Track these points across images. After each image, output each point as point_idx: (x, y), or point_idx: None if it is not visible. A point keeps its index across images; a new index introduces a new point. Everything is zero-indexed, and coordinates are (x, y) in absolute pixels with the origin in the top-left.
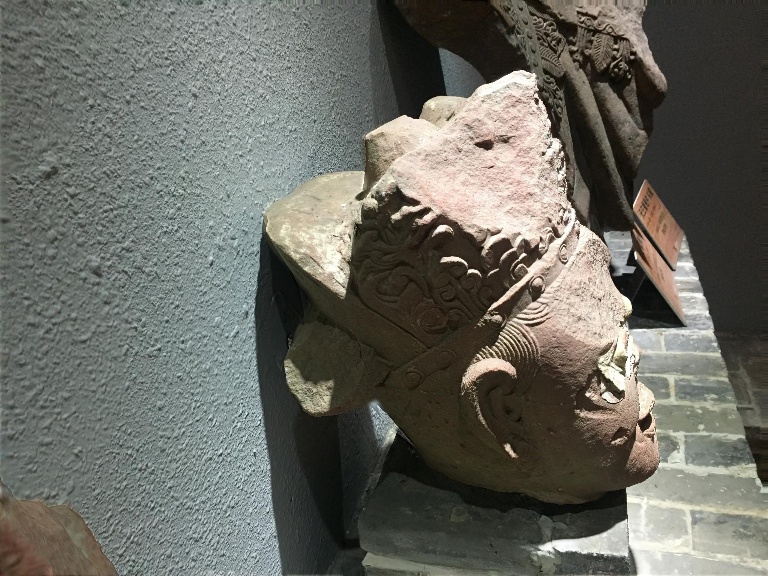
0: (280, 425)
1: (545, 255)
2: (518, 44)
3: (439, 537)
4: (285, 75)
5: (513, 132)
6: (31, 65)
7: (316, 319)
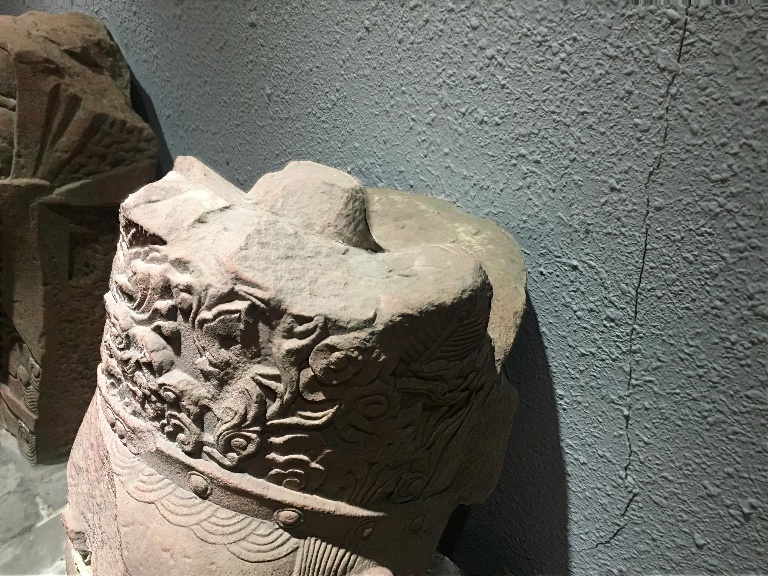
0: None
1: None
2: None
3: None
4: (545, 77)
5: None
6: None
7: None
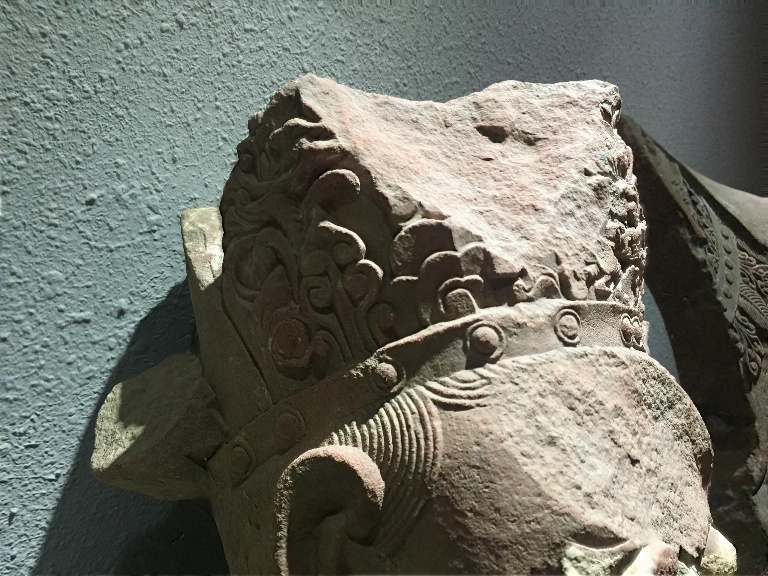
0: (99, 518)
1: (524, 304)
2: (705, 260)
3: None
4: None
5: (547, 134)
6: None
7: (191, 348)
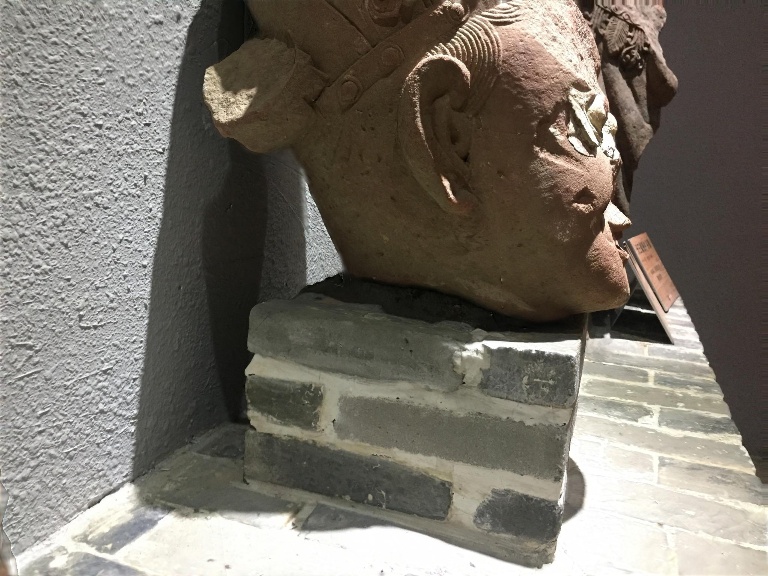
0: (188, 186)
1: None
2: None
3: (344, 327)
4: None
5: None
6: None
7: (255, 37)
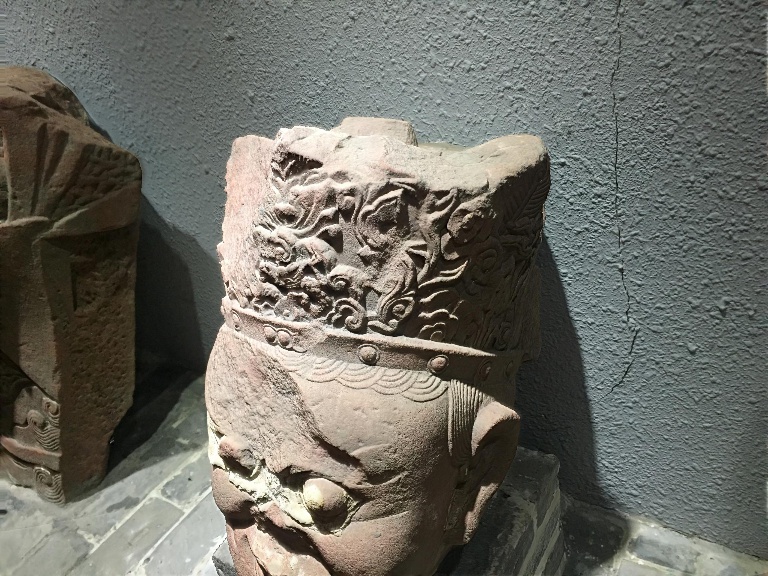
0: None
1: (229, 300)
2: None
3: None
4: (520, 23)
5: None
6: None
7: None
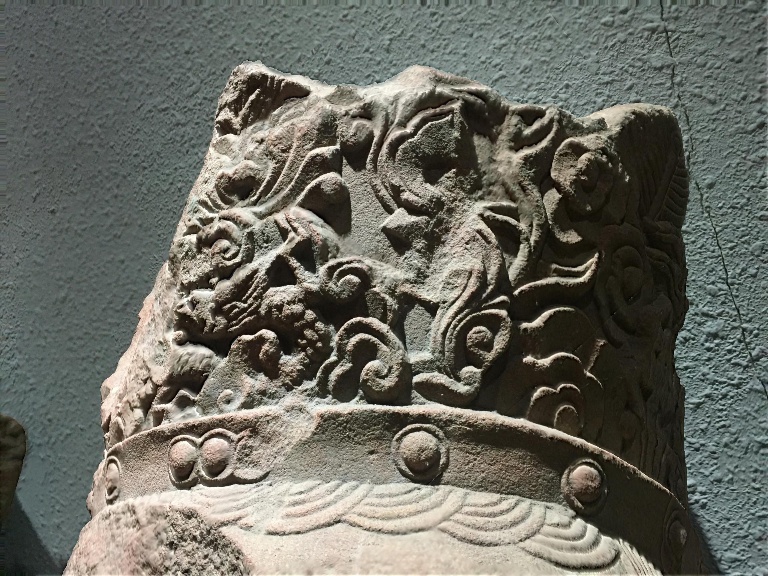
0: None
1: None
2: None
3: None
4: None
5: None
6: (174, 188)
7: None
